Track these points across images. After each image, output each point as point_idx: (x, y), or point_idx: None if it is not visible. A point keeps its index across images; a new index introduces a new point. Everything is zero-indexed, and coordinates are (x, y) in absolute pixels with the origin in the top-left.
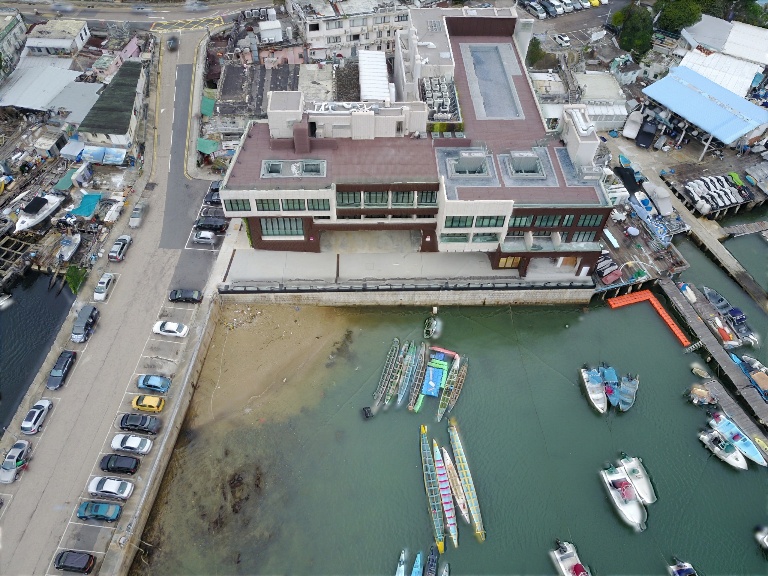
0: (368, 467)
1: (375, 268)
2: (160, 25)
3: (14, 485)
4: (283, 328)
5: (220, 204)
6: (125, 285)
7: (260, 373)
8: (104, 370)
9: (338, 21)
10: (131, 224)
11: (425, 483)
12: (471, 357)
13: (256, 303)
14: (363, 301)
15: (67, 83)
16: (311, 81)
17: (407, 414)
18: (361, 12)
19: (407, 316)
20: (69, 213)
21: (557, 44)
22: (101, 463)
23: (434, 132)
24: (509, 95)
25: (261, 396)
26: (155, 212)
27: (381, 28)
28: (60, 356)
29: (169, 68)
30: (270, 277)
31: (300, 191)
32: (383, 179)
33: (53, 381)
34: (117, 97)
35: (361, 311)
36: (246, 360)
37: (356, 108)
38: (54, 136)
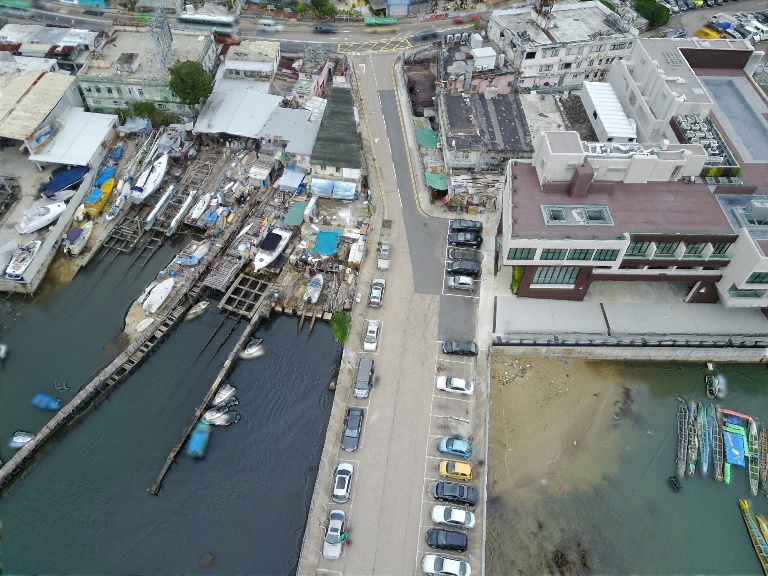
0: (693, 545)
1: (645, 320)
2: (346, 46)
3: (340, 561)
4: (557, 383)
5: (466, 245)
6: (391, 334)
7: (548, 434)
8: (396, 430)
9: (556, 49)
10: (381, 266)
11: (764, 567)
12: (765, 421)
13: (523, 355)
14: (636, 355)
15: (271, 108)
16: (538, 113)
17: (719, 486)
18: (578, 40)
19: (680, 372)
20: (304, 250)
21: (767, 75)
22: (428, 538)
23: (708, 176)
24: (763, 135)
25: (556, 461)
26: (400, 253)
27: (595, 57)
28: (350, 414)
29: (370, 94)
30: (541, 328)
31: (595, 241)
32: (675, 229)
33: (349, 442)
34: (339, 127)
35: (631, 365)
36: (530, 419)
37: (634, 151)
38: (267, 165)
